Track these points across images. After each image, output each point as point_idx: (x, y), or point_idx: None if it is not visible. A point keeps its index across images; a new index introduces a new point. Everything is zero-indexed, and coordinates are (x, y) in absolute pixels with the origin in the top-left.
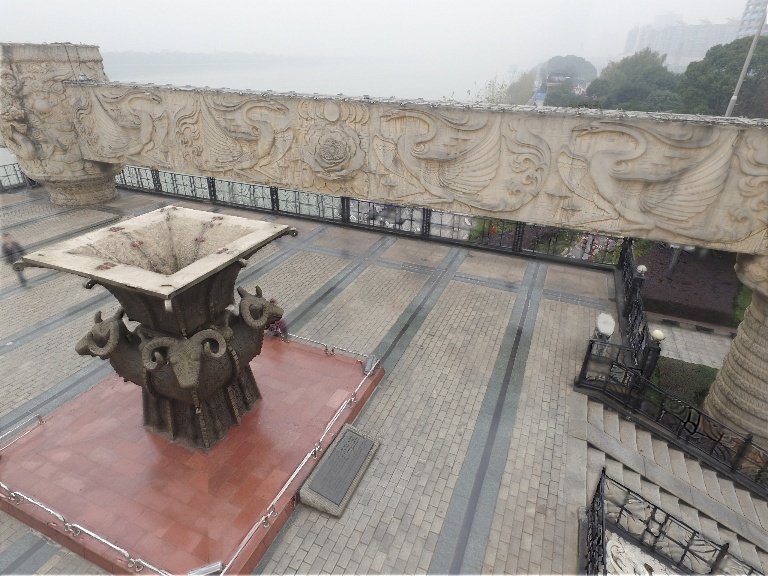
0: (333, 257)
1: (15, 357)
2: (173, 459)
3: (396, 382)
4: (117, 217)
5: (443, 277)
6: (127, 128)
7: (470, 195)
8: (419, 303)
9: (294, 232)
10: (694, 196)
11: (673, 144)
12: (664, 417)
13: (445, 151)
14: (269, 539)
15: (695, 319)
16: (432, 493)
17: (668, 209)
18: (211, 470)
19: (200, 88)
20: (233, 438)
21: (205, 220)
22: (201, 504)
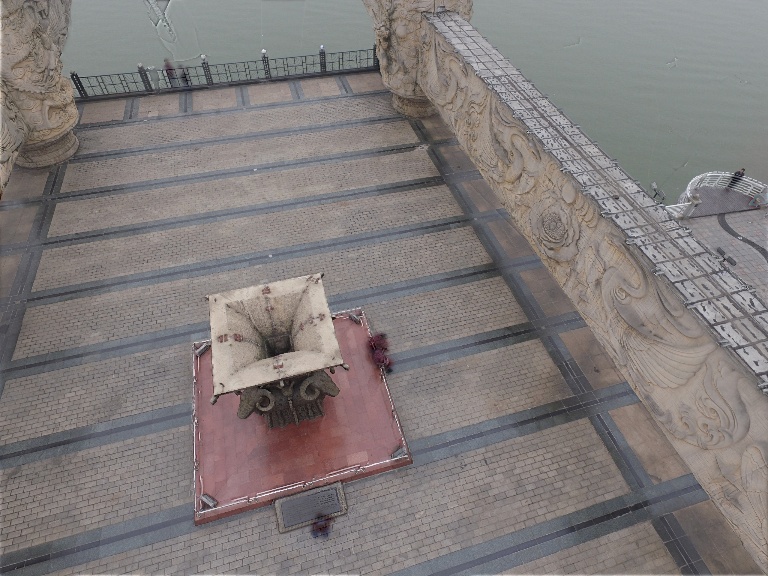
0: (517, 304)
1: (264, 271)
2: (255, 418)
3: (409, 478)
4: (416, 144)
5: (584, 407)
6: None
7: (642, 377)
8: (521, 420)
9: (346, 368)
10: None
11: None
12: None
13: (643, 319)
14: (246, 509)
15: None
16: (332, 575)
17: None
18: (260, 443)
19: (504, 76)
20: (286, 432)
21: (314, 313)
22: (240, 459)
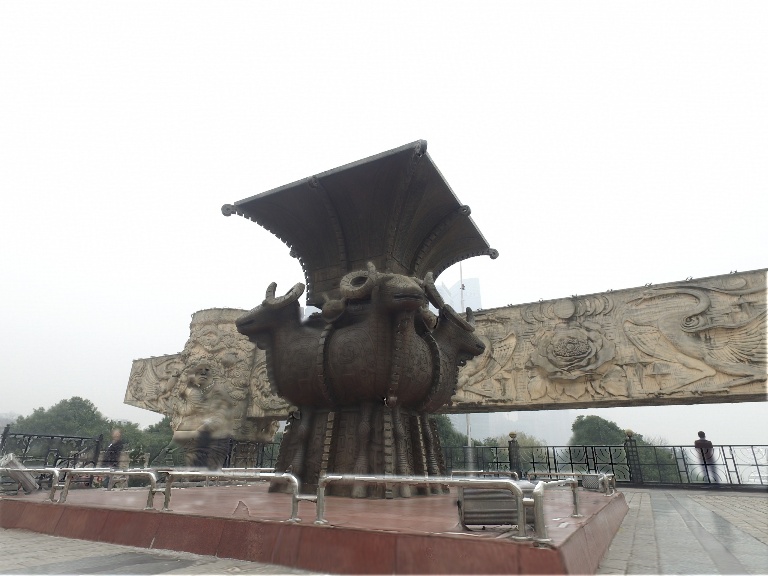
0: None
1: None
2: None
3: None
4: None
5: None
6: None
7: None
8: None
9: (228, 210)
10: None
11: None
12: None
13: None
14: None
15: None
16: None
17: None
18: None
19: None
20: None
21: None
22: None
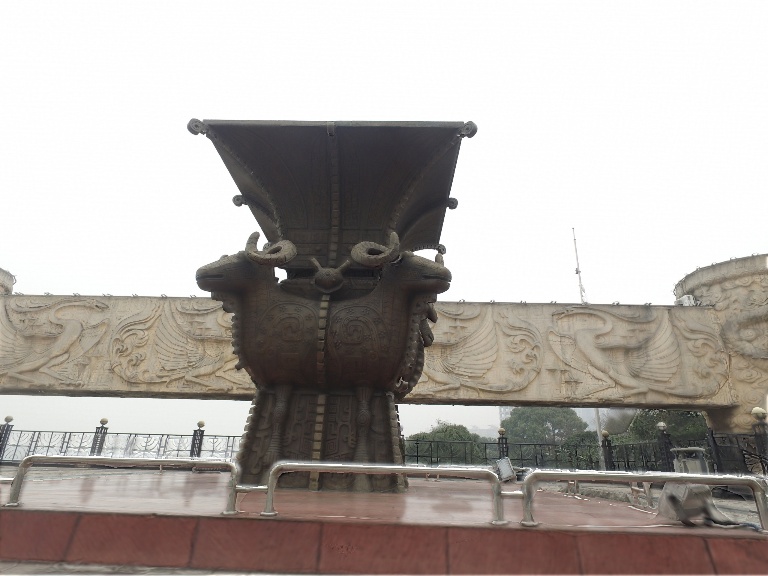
0: None
1: None
2: (350, 494)
3: None
4: None
5: None
6: (36, 338)
7: (476, 379)
8: None
9: (443, 248)
10: (663, 360)
11: (630, 320)
12: None
13: (445, 339)
14: None
15: None
16: None
17: (651, 372)
18: None
19: None
20: None
21: None
22: None
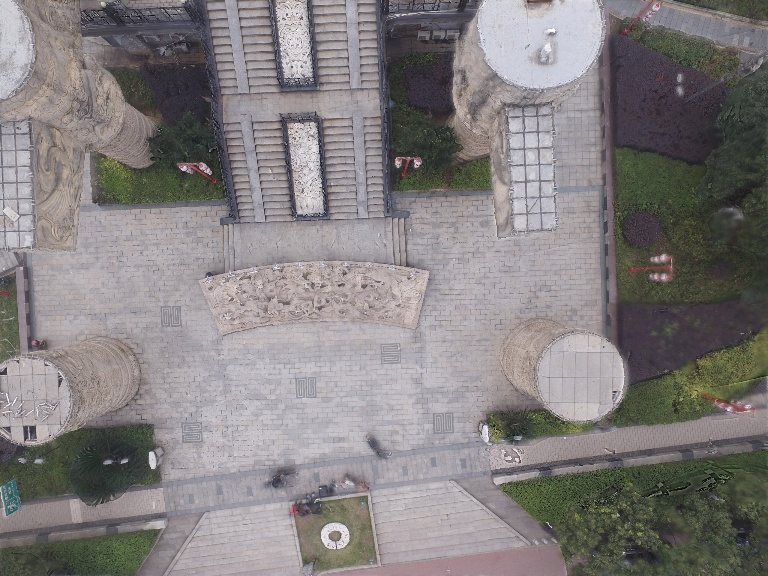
0: None
1: None
2: None
3: None
4: None
5: None
6: None
7: None
8: None
9: None
10: None
11: None
12: (382, 29)
13: None
14: None
15: (612, 123)
16: None
17: None
18: None
19: None
20: None
21: None
22: None
